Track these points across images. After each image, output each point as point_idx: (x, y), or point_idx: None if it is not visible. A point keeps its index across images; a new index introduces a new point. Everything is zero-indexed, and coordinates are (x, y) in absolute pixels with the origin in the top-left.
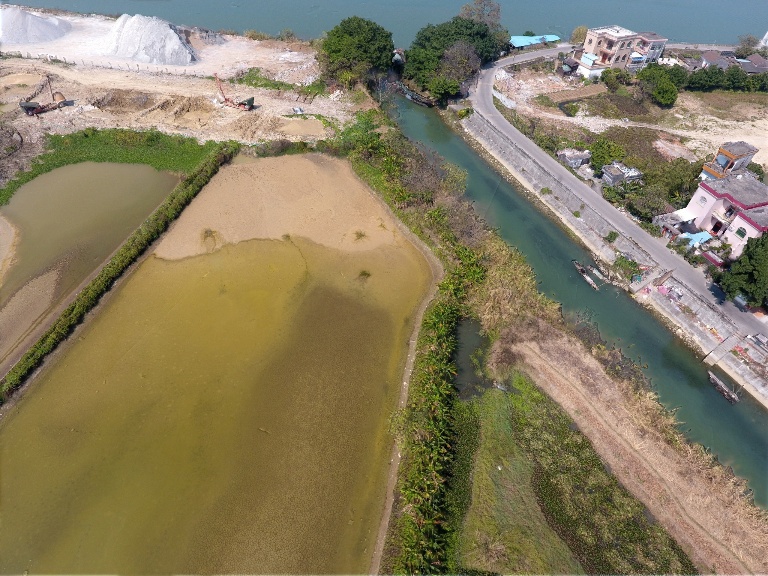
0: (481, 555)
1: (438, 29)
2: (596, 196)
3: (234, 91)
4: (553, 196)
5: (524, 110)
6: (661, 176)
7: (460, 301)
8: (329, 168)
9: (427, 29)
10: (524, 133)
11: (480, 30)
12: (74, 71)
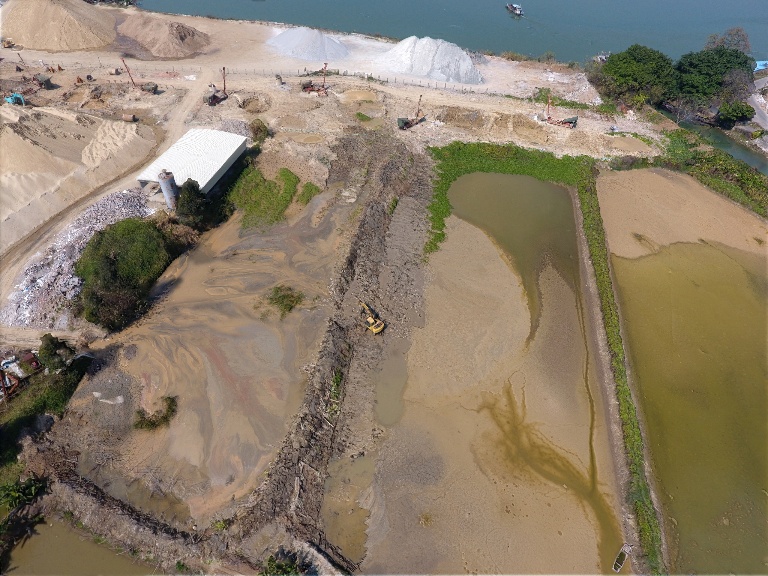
0: None
1: (705, 57)
2: None
3: (540, 109)
4: None
5: None
6: None
7: None
8: (679, 181)
9: (689, 56)
10: None
11: None
12: (393, 88)
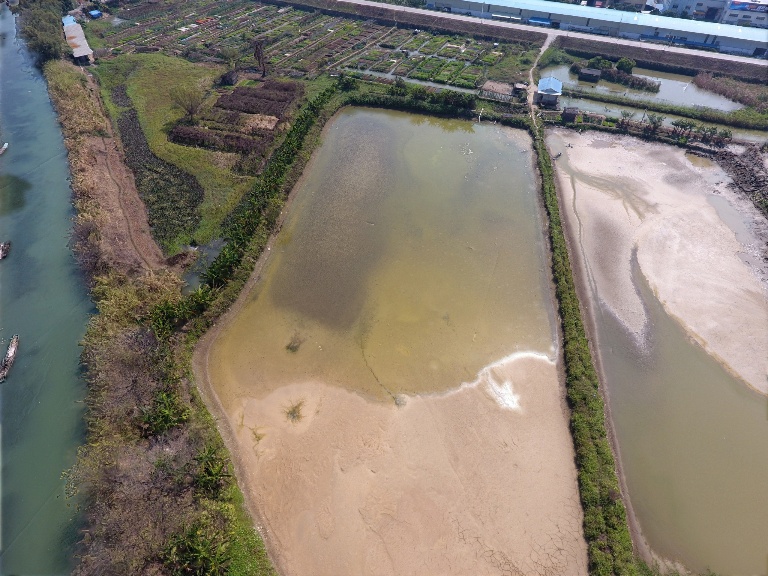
0: (246, 176)
1: None
2: None
3: None
4: None
5: None
6: None
7: None
8: None
9: None
10: None
11: None
12: None
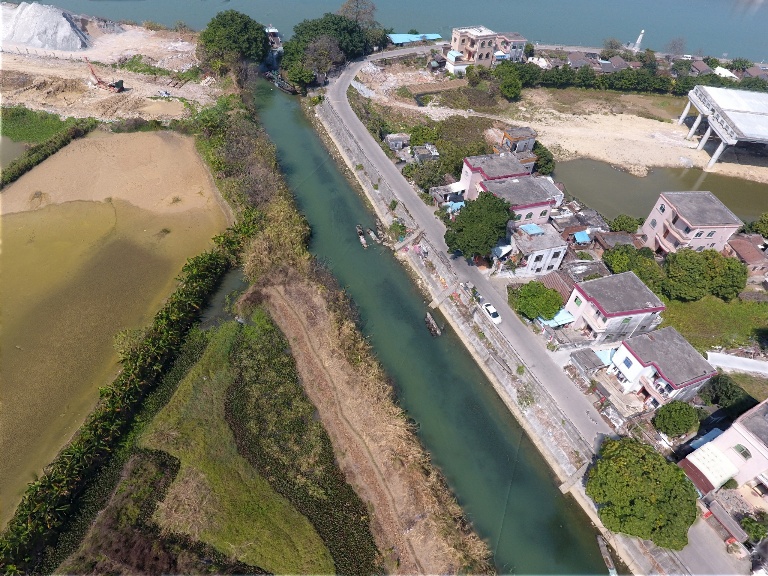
0: (153, 437)
1: (310, 24)
2: (395, 171)
3: (113, 75)
4: (363, 172)
5: (380, 99)
6: (449, 155)
7: (233, 253)
8: (174, 144)
9: (303, 24)
10: (360, 118)
11: (348, 26)
12: None
